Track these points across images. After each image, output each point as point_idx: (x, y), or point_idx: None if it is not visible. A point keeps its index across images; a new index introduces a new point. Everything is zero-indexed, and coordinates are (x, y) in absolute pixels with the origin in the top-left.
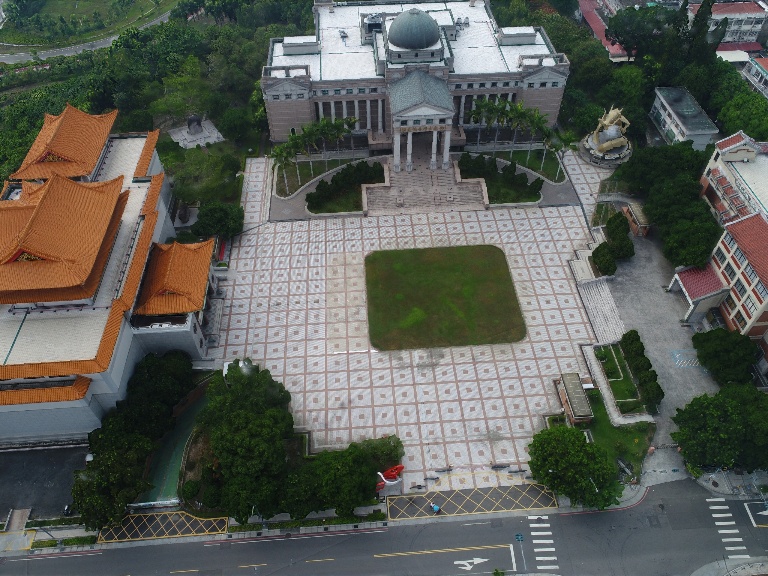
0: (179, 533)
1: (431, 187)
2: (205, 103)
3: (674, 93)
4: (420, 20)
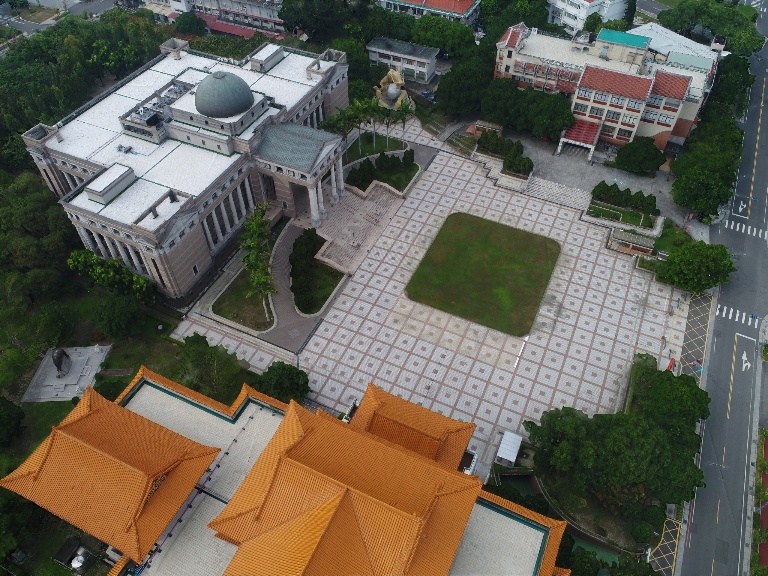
0: (671, 567)
1: (354, 216)
2: (45, 329)
3: (379, 43)
4: (234, 79)
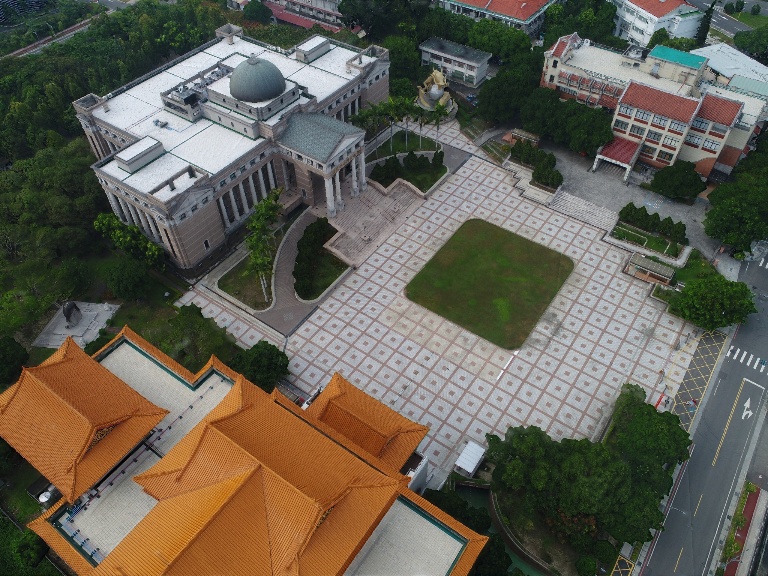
0: None
1: (372, 211)
2: (62, 282)
3: (433, 44)
4: (267, 66)
